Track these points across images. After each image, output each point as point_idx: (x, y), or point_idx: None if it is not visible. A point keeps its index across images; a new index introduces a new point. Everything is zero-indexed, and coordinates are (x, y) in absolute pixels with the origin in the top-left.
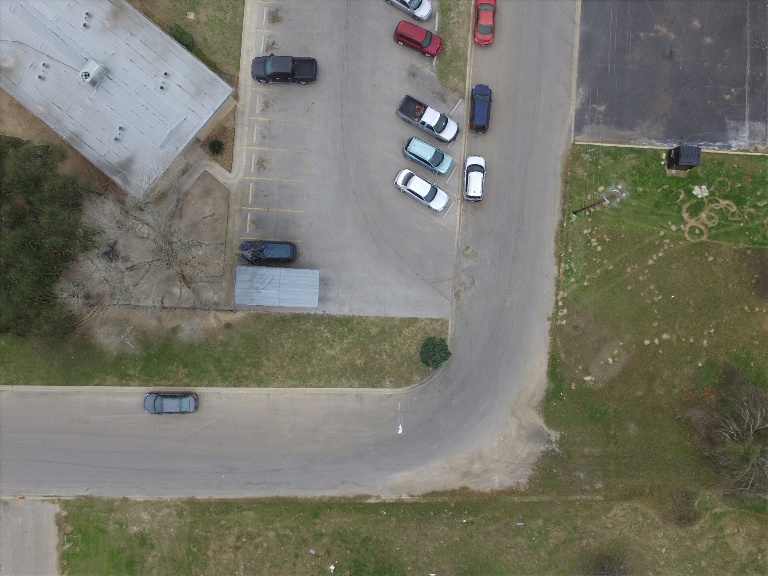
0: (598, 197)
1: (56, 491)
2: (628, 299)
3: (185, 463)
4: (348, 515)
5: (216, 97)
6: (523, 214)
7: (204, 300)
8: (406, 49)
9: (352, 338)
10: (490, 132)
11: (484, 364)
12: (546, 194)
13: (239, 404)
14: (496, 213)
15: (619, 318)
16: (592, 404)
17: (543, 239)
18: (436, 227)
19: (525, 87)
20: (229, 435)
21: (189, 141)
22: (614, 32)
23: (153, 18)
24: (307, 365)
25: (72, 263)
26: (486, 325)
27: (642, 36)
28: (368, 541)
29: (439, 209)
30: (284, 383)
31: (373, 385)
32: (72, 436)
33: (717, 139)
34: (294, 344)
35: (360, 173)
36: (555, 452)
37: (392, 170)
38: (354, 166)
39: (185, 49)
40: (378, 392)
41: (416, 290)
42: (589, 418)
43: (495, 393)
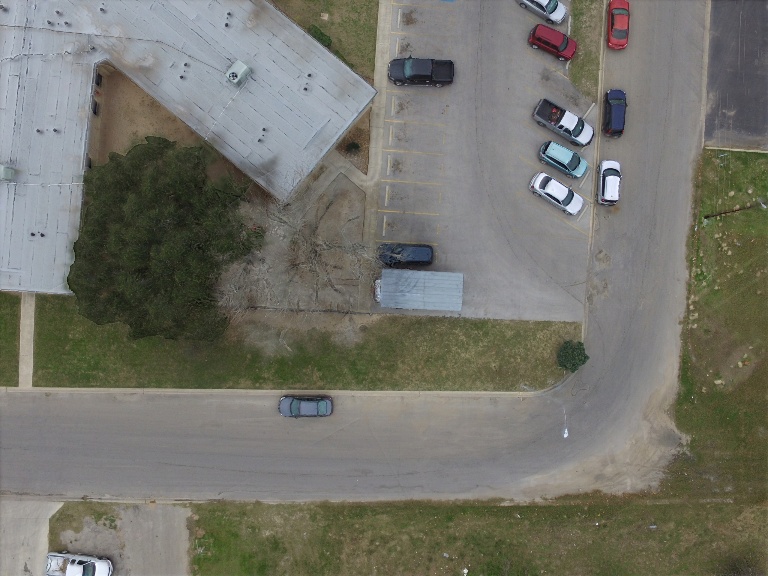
0: (729, 202)
1: (188, 495)
2: (758, 303)
3: (319, 467)
4: (482, 518)
5: (360, 99)
6: (655, 218)
7: (341, 303)
8: (539, 53)
9: (487, 341)
10: (623, 136)
11: (616, 368)
12: (678, 199)
13: (373, 407)
14: (629, 217)
15: (749, 322)
16: (722, 407)
17: (675, 243)
18: (570, 231)
19: (657, 92)
20: (363, 438)
21: (333, 143)
22: (743, 38)
23: (292, 19)
24: (442, 368)
25: (231, 266)
26: (619, 329)
27: None
28: (501, 544)
29: (574, 213)
30: (419, 386)
31: (507, 388)
32: (204, 439)
33: None
34: (429, 347)
35: (495, 176)
36: (686, 455)
37: (526, 174)
38: (489, 169)
39: (328, 51)
40: (512, 395)
41: (550, 294)
42: (719, 421)
43: (627, 396)
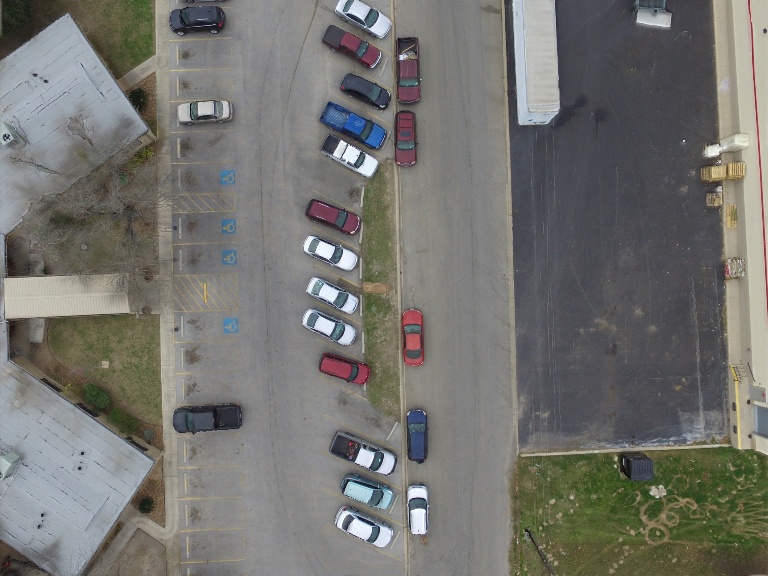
0: (550, 510)
1: None
2: None
3: None
4: None
5: (137, 472)
6: (473, 537)
7: None
8: None
9: None
10: (430, 455)
11: None
12: (495, 513)
13: None
14: (444, 539)
15: None
16: None
17: (496, 560)
18: (383, 560)
19: (463, 402)
20: None
21: (115, 521)
22: None
23: None
24: None
25: None
26: None
27: (582, 332)
28: None
29: (384, 546)
30: None
31: None
32: None
33: (671, 433)
34: None
35: (299, 513)
36: None
37: (332, 506)
38: (292, 506)
39: (100, 423)
40: None
41: None
42: None
43: None
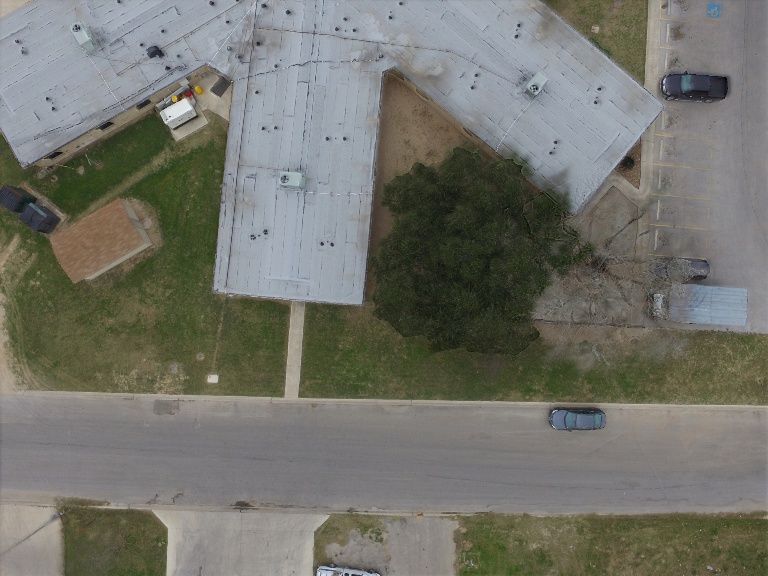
0: None
1: (455, 508)
2: None
3: (587, 480)
4: (745, 531)
5: (648, 114)
6: None
7: (614, 316)
8: None
9: (753, 356)
10: None
11: None
12: None
13: (640, 420)
14: None
15: None
16: None
17: None
18: None
19: None
20: (631, 451)
21: (622, 157)
22: None
23: None
24: (709, 382)
25: (555, 280)
26: None
27: None
28: (763, 557)
29: None
30: (685, 400)
31: None
32: (474, 452)
33: None
34: (697, 361)
35: (760, 192)
36: None
37: None
38: (754, 185)
39: (615, 65)
40: None
41: None
42: None
43: None
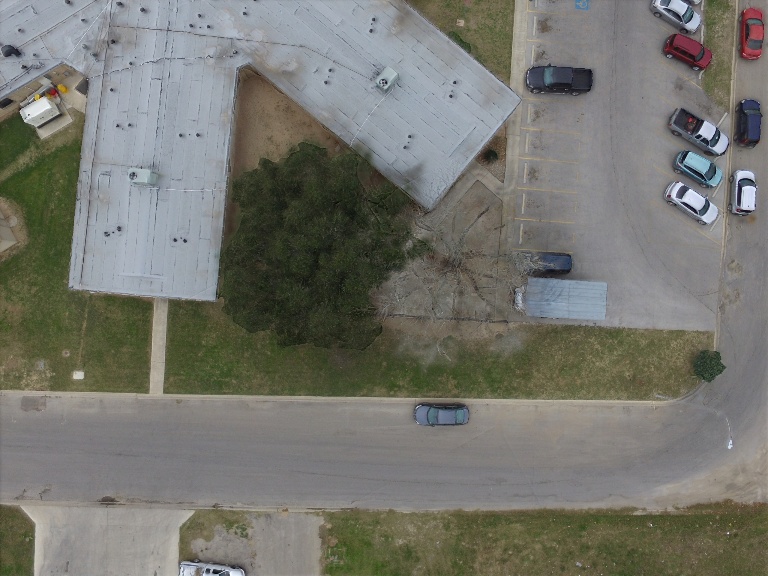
0: None
1: (320, 503)
2: None
3: (453, 475)
4: (615, 527)
5: (505, 107)
6: None
7: (478, 311)
8: (673, 62)
9: (622, 350)
10: (755, 146)
11: (748, 377)
12: None
13: (507, 416)
14: (761, 227)
15: None
16: None
17: None
18: (703, 240)
19: None
20: (497, 447)
21: (478, 151)
22: None
23: None
24: (576, 377)
25: (393, 274)
26: (750, 338)
27: None
28: (634, 553)
29: (709, 223)
30: (553, 395)
31: (641, 398)
32: (338, 448)
33: None
34: (564, 356)
35: (629, 185)
36: None
37: (660, 183)
38: (623, 178)
39: (472, 58)
40: (645, 404)
41: (684, 303)
42: None
43: (758, 406)
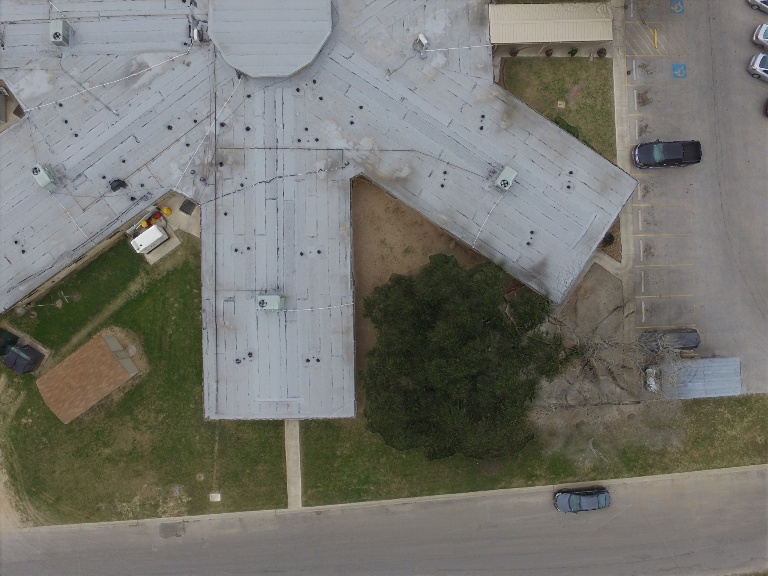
0: None
1: None
2: None
3: (597, 557)
4: None
5: (623, 192)
6: None
7: (609, 394)
8: None
9: (752, 416)
10: None
11: None
12: None
13: (645, 493)
14: None
15: None
16: None
17: None
18: None
19: None
20: (638, 524)
21: (601, 239)
22: None
23: None
24: (709, 447)
25: (544, 384)
26: None
27: None
28: None
29: None
30: (688, 467)
31: None
32: (482, 542)
33: None
34: (695, 428)
35: (744, 251)
36: None
37: None
38: (738, 244)
39: (585, 145)
40: None
41: None
42: None
43: None
